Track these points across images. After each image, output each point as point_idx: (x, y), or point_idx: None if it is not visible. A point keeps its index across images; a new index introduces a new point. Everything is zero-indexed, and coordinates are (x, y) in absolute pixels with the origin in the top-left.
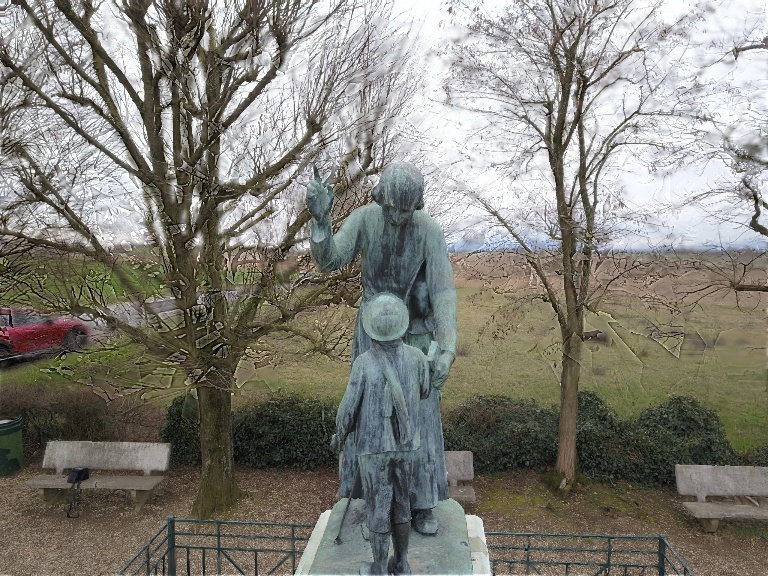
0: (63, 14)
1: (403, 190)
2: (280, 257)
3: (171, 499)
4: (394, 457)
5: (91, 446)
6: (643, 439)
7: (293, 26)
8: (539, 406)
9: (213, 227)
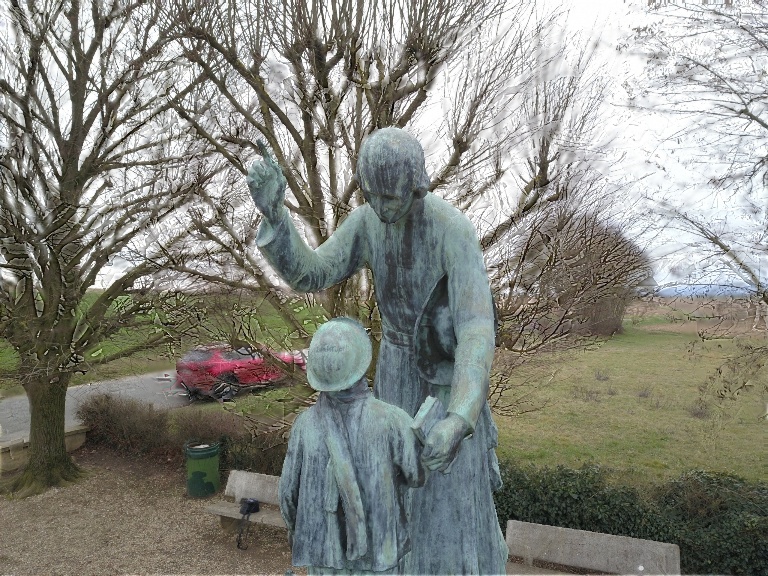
0: (231, 65)
1: (378, 165)
2: None
3: None
4: None
5: (265, 479)
6: None
7: (441, 41)
8: None
9: None
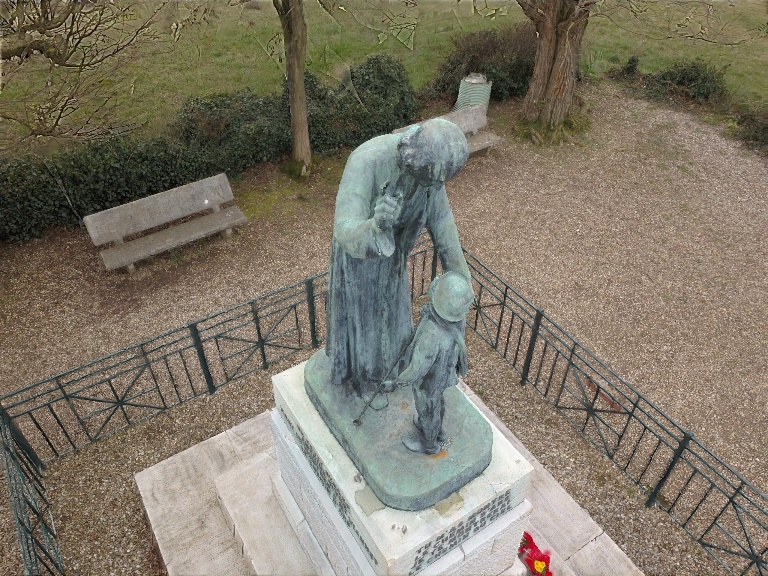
0: None
1: (459, 166)
2: None
3: None
4: None
5: None
6: (357, 108)
7: None
8: (259, 96)
9: None
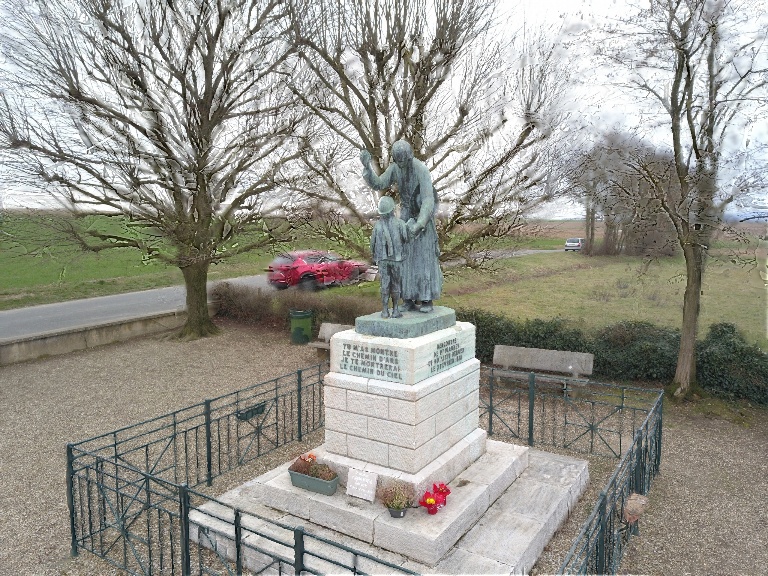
0: (323, 59)
1: (397, 152)
2: None
3: None
4: (389, 263)
5: (344, 327)
6: (767, 365)
7: (454, 45)
8: (677, 333)
9: None
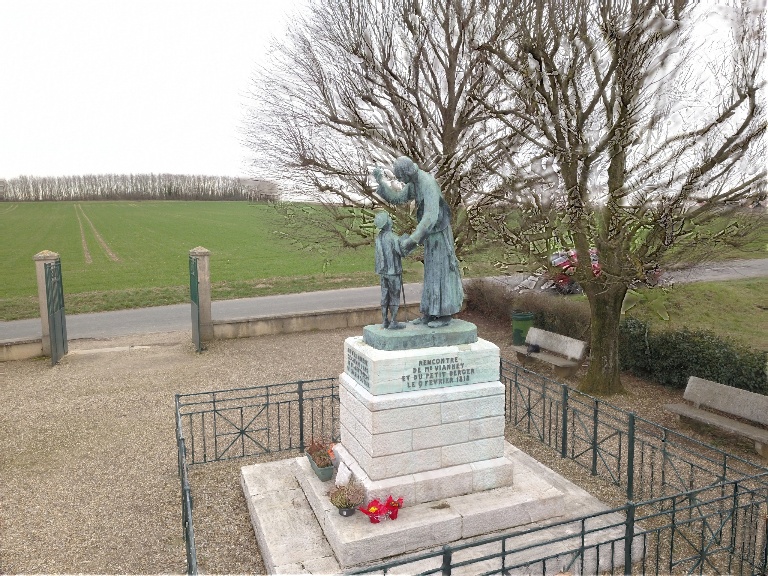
0: (503, 60)
1: None
2: None
3: None
4: (384, 276)
5: (547, 334)
6: None
7: (623, 23)
8: None
9: (592, 183)
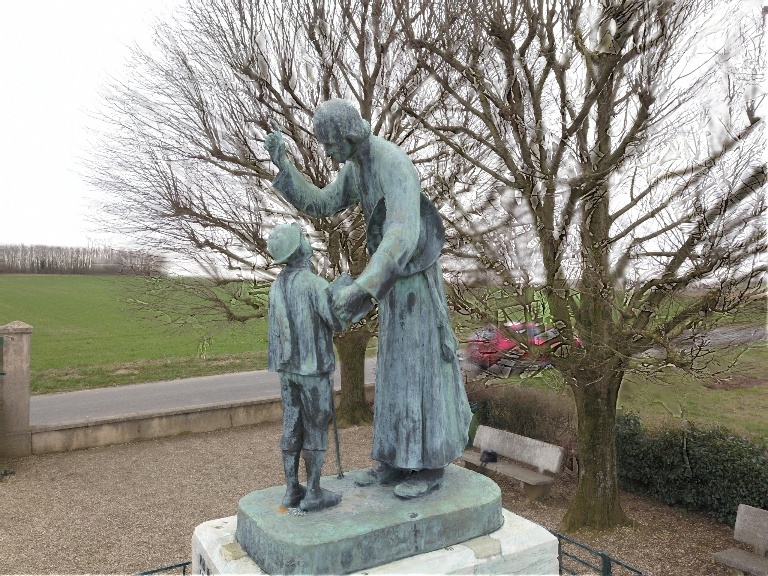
0: (449, 64)
1: (317, 124)
2: (606, 250)
3: (561, 504)
4: (291, 378)
5: (505, 435)
6: None
7: None
8: None
9: None
